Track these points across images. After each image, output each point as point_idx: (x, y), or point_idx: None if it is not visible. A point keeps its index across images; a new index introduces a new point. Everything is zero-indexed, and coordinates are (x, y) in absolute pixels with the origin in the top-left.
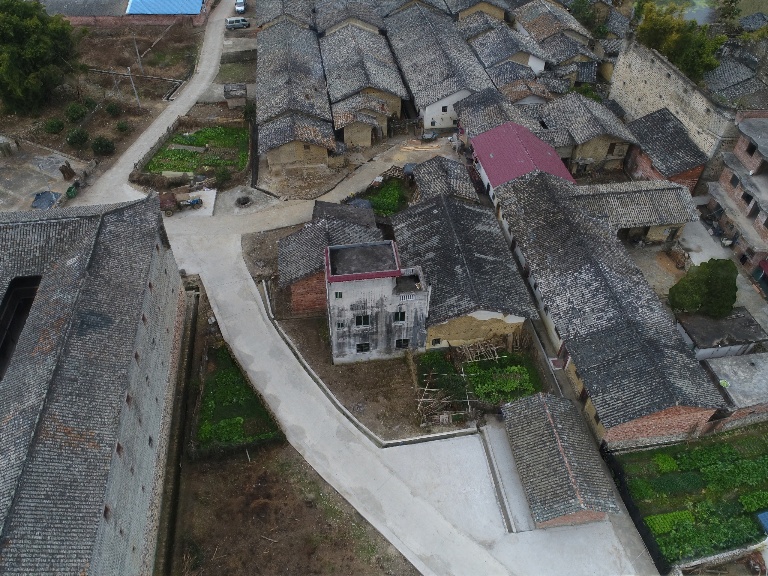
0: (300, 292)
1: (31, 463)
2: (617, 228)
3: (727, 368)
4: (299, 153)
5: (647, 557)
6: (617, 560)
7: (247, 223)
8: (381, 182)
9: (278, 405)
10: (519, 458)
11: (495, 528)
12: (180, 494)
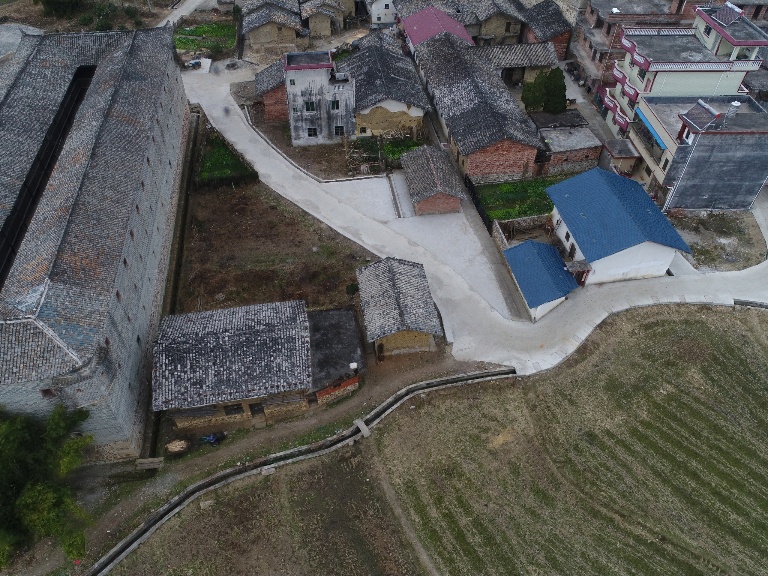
0: (270, 103)
1: (106, 123)
2: (498, 67)
3: (553, 135)
4: (274, 34)
5: (483, 227)
6: (464, 228)
7: (234, 77)
8: (336, 54)
9: (254, 164)
10: (407, 177)
11: (390, 216)
12: (189, 204)
